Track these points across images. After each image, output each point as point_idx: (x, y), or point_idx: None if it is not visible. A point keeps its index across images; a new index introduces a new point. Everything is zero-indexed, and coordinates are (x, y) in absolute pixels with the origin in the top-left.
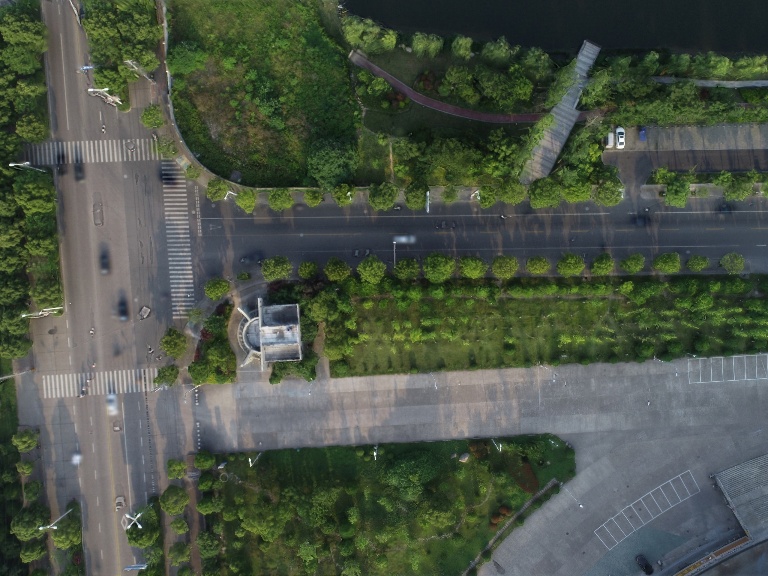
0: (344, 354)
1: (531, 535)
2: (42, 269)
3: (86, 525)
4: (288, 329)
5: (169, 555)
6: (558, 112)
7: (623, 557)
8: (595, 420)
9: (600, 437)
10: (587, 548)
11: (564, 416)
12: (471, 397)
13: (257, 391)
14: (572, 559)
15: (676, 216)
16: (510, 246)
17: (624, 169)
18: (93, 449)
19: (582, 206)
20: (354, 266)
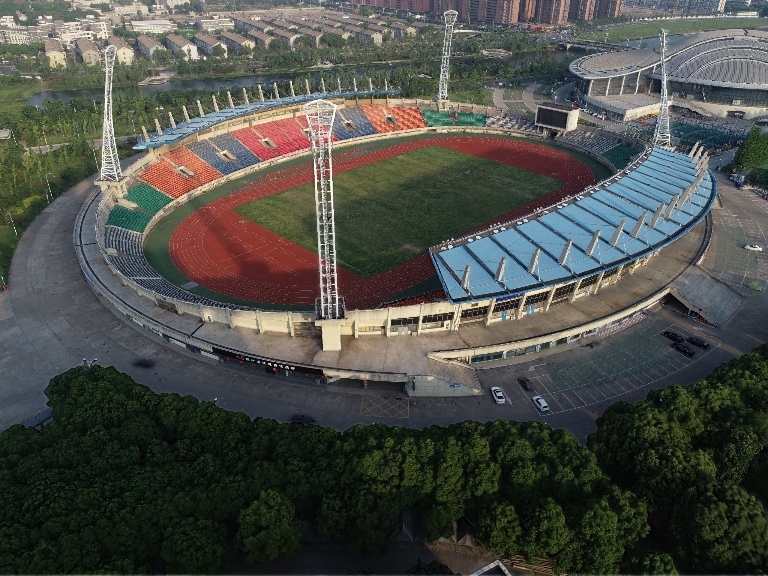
0: (32, 132)
1: None
2: None
3: None
4: (4, 128)
5: None
6: None
7: None
8: None
9: None
10: None
11: None
12: None
13: None
14: None
15: None
16: None
17: None
18: None
19: None
20: None
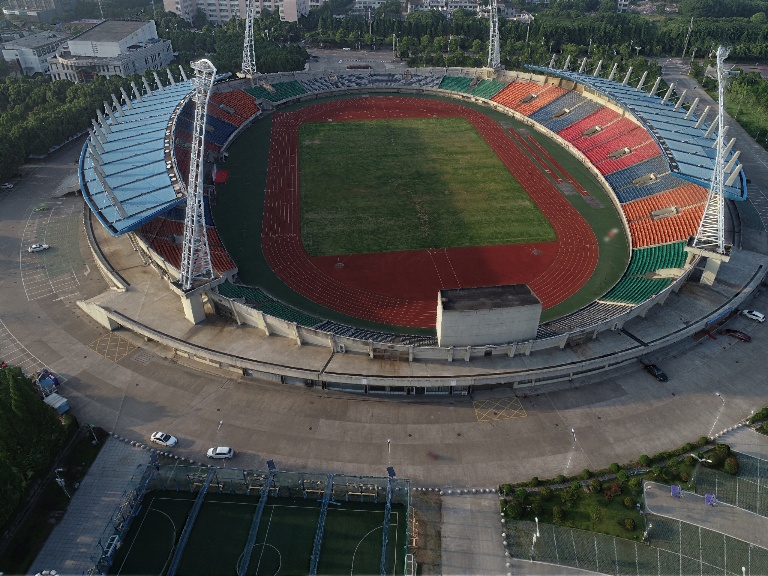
0: None
1: None
2: (730, 52)
3: None
4: None
5: None
6: None
7: None
8: None
9: None
10: None
11: None
12: None
13: None
14: None
15: None
16: None
17: None
18: None
19: None
20: None
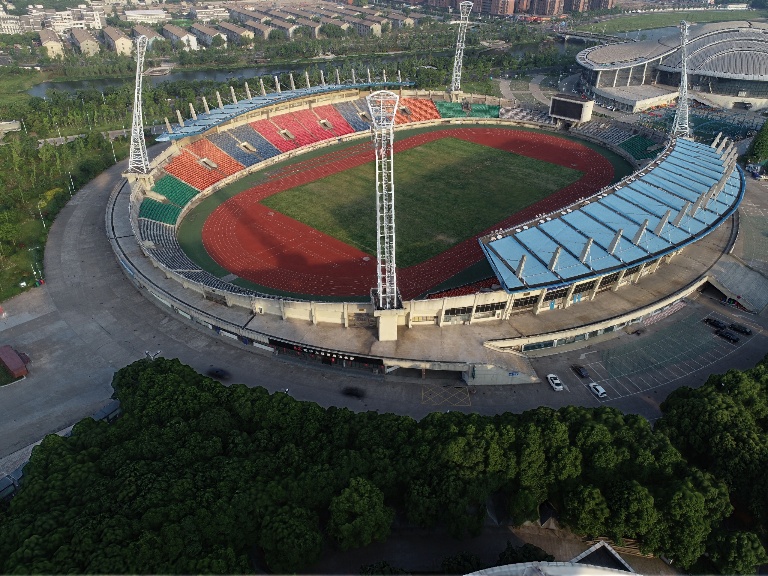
0: None
1: None
2: None
3: None
4: (14, 120)
5: None
6: None
7: None
8: None
9: None
10: None
11: None
12: None
13: None
14: None
15: None
16: None
17: None
18: None
19: None
20: (50, 115)
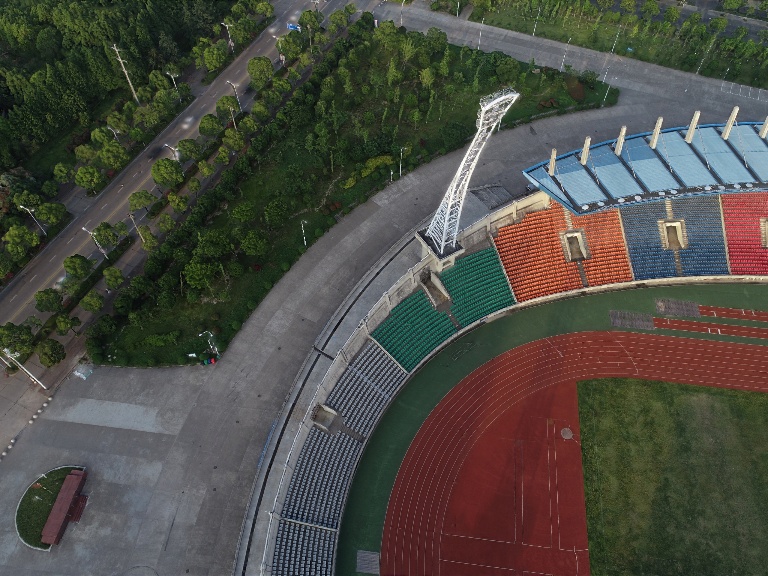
0: None
1: (567, 123)
2: None
3: (272, 27)
4: None
5: (318, 32)
6: None
7: None
8: (641, 86)
9: (642, 95)
10: None
11: (618, 78)
12: (555, 52)
13: (418, 12)
14: None
15: (730, 26)
16: (612, 8)
17: (699, 2)
18: (305, 4)
19: None
20: None
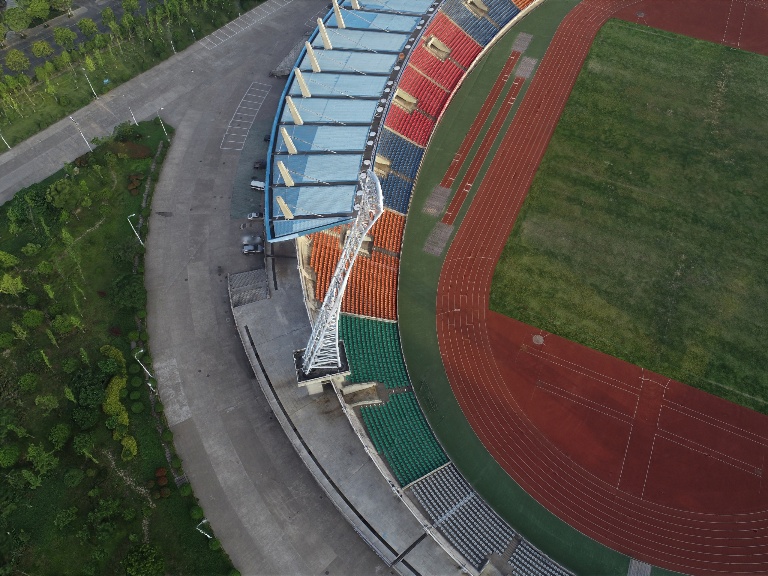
0: None
1: (173, 180)
2: None
3: None
4: None
5: None
6: (12, 4)
7: (256, 147)
8: (163, 99)
9: (175, 104)
10: (224, 159)
11: (138, 110)
12: (56, 142)
13: None
14: (219, 172)
15: None
16: None
17: (78, 2)
18: None
19: (63, 26)
20: None
